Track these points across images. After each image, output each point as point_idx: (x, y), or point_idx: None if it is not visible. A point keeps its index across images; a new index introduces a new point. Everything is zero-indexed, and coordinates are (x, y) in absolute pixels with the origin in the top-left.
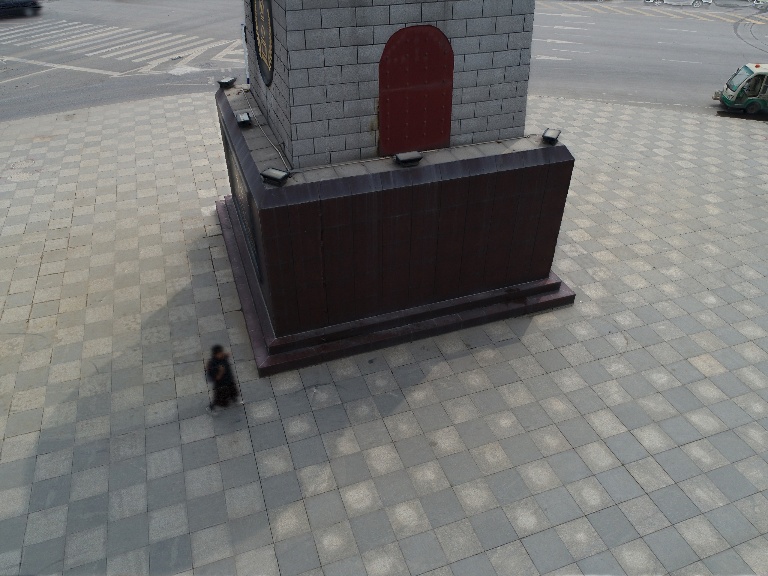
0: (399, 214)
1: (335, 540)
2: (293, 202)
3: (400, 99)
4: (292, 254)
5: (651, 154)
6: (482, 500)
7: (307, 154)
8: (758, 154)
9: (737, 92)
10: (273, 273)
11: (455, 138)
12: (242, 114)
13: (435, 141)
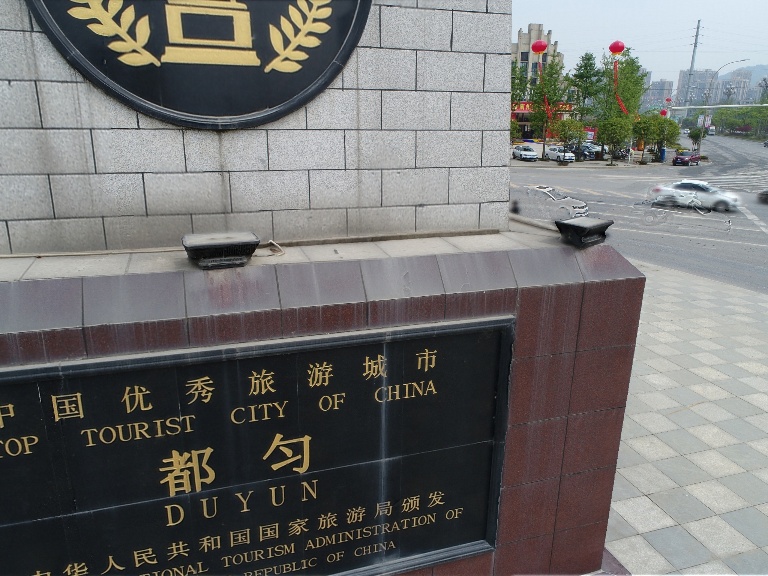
0: None
1: None
2: None
3: None
4: None
5: None
6: None
7: None
8: None
9: None
10: None
11: None
12: None
13: None
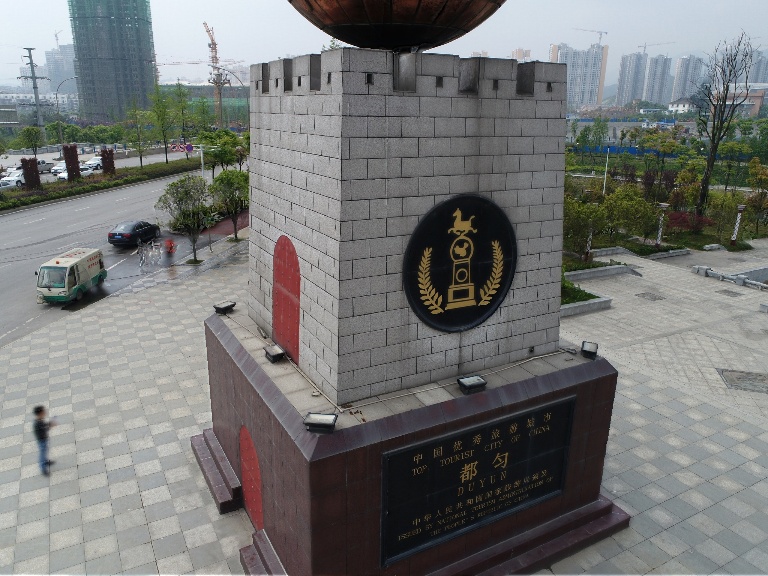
0: None
1: (717, 464)
2: None
3: None
4: None
5: (168, 340)
6: (638, 418)
7: None
8: (181, 307)
9: (67, 287)
10: None
11: None
12: (463, 382)
13: None
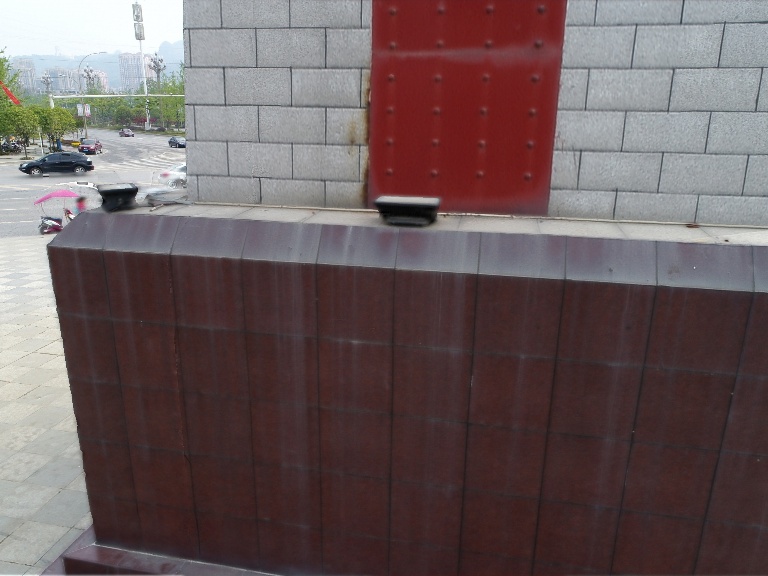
0: (360, 338)
1: None
2: (116, 246)
3: (421, 78)
4: (117, 366)
5: None
6: None
7: (214, 174)
8: None
9: None
10: (82, 397)
11: (563, 197)
12: None
13: (509, 196)
